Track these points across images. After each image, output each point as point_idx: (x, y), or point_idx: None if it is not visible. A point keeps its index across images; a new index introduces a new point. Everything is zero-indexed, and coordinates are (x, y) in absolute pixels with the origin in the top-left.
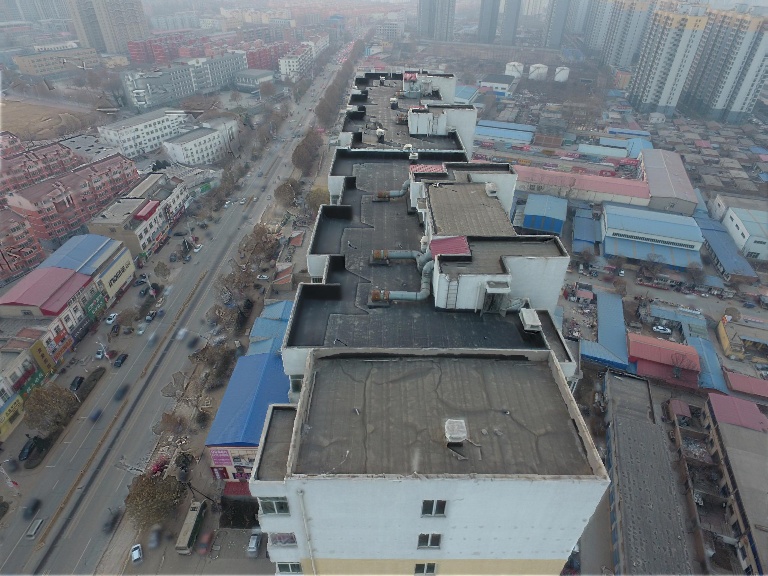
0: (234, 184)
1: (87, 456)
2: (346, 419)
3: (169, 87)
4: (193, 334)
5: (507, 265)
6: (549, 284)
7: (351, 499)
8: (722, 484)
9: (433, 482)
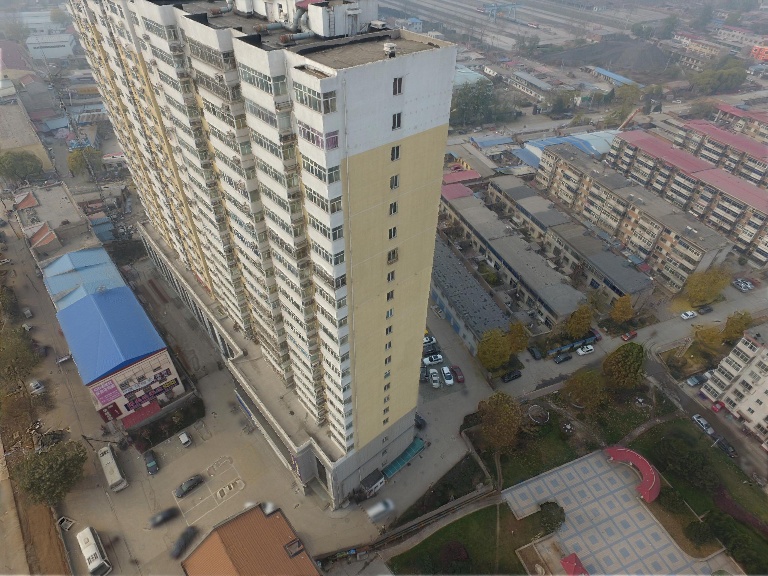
0: None
1: None
2: (334, 64)
3: None
4: None
5: (351, 1)
6: (371, 19)
7: (365, 85)
8: (465, 234)
9: (397, 59)
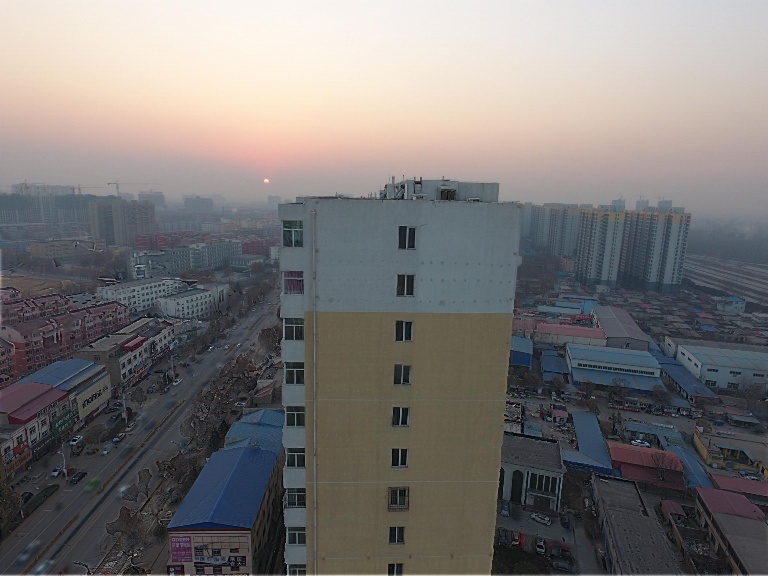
0: (220, 333)
1: (18, 573)
2: None
3: (168, 264)
4: (161, 454)
5: None
6: None
7: (349, 224)
8: None
9: (405, 202)
